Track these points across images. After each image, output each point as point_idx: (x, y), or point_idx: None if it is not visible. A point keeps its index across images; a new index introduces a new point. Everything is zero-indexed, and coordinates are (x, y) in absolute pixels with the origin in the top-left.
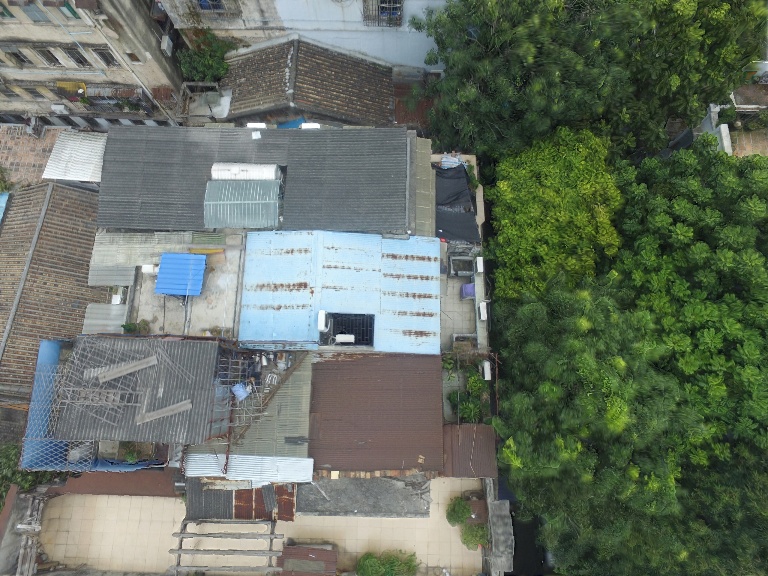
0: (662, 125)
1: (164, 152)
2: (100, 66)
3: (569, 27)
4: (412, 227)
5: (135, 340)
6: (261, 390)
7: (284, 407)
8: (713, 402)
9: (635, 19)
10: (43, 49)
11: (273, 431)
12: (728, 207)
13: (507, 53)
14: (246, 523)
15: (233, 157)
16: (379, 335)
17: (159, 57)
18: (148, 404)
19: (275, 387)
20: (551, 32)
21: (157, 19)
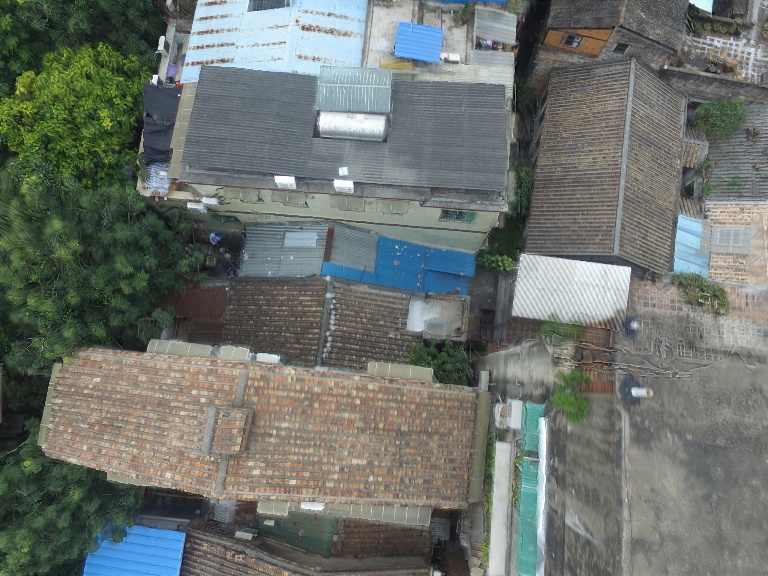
0: None
1: (442, 158)
2: None
3: None
4: None
5: None
6: None
7: None
8: None
9: None
10: None
11: None
12: None
13: None
14: None
15: (369, 150)
16: None
17: None
18: None
19: None
20: None
21: None
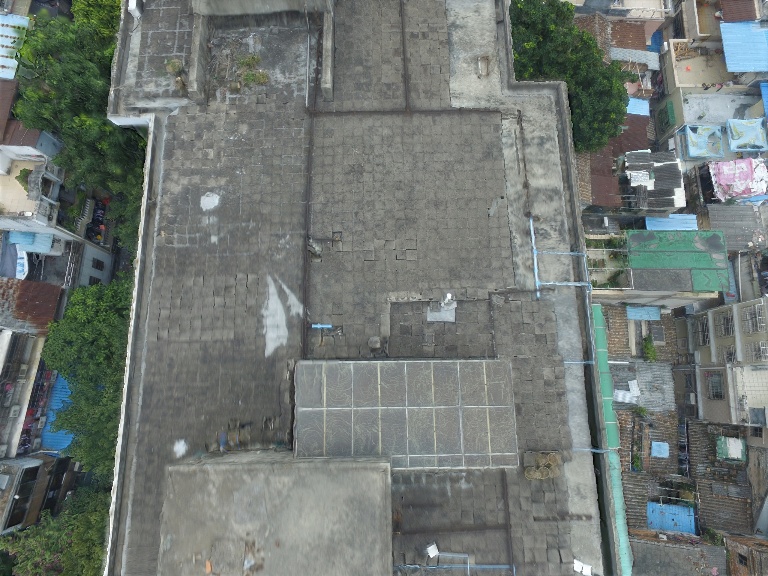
0: None
1: None
2: None
3: None
4: (9, 8)
5: None
6: None
7: None
8: None
9: None
10: None
11: None
12: None
13: None
14: None
15: None
16: None
17: None
18: None
19: None
20: None
21: None
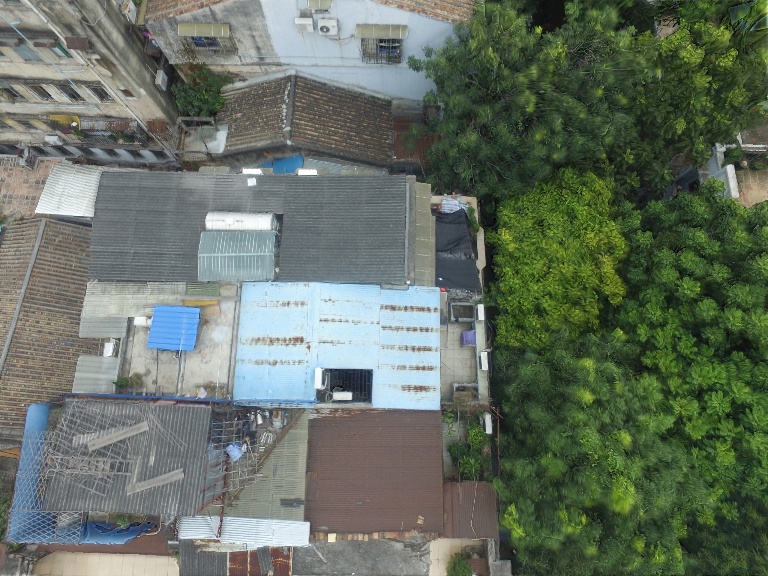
0: (667, 166)
1: (157, 200)
2: (93, 101)
3: (573, 75)
4: (411, 277)
5: (126, 404)
6: (256, 449)
7: (280, 467)
8: (721, 466)
9: (640, 67)
10: (35, 85)
11: (268, 492)
12: (736, 263)
13: (509, 97)
14: None
15: (228, 205)
16: (377, 391)
17: (154, 92)
18: (139, 473)
19: (270, 446)
20: (554, 79)
21: (151, 55)
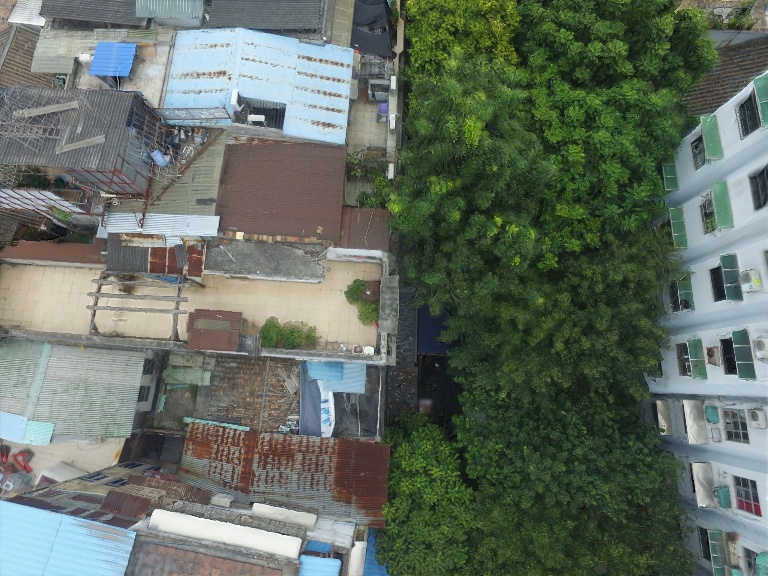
0: None
1: None
2: None
3: None
4: (328, 35)
5: None
6: (178, 160)
7: (198, 175)
8: (575, 174)
9: None
10: None
11: (186, 195)
12: (603, 9)
13: None
14: (158, 275)
15: None
16: (289, 121)
17: None
18: (67, 138)
19: (191, 158)
20: None
21: None
